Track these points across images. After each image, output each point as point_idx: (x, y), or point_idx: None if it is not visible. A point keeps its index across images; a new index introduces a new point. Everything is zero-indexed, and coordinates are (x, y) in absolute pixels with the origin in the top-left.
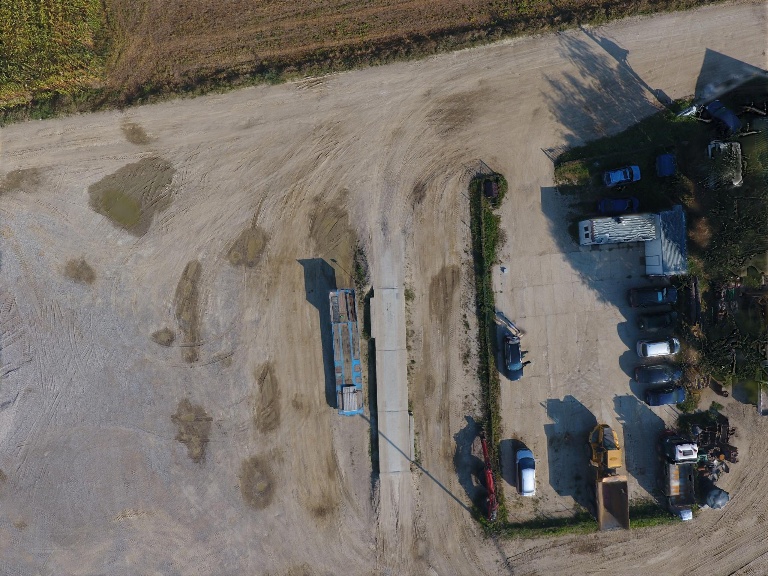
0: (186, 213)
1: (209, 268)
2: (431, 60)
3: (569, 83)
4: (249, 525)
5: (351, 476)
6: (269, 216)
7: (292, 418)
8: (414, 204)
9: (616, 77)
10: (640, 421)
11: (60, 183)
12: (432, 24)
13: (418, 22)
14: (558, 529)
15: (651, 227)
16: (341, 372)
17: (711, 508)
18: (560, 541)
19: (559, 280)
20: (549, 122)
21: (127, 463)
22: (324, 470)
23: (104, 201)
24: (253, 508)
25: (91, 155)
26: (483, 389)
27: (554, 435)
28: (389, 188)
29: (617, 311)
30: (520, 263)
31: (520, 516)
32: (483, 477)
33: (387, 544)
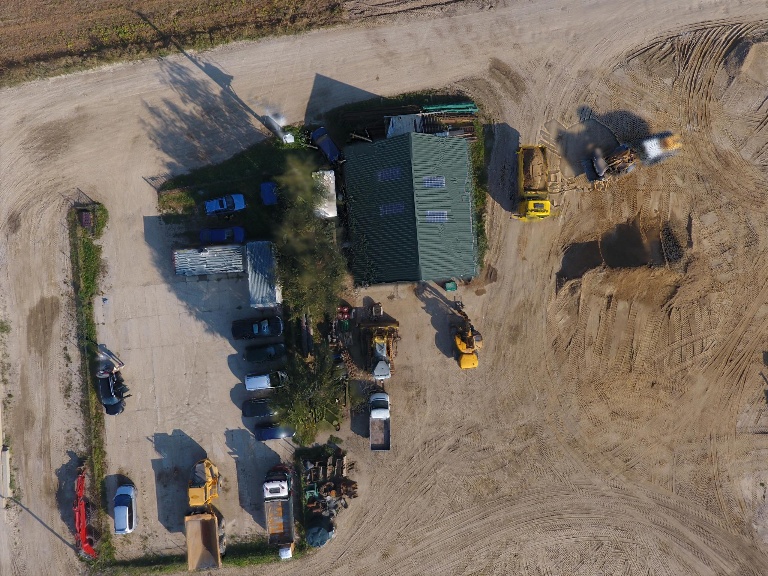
0: None
1: None
2: (24, 87)
3: (170, 110)
4: None
5: None
6: None
7: None
8: (8, 234)
9: (220, 103)
10: (254, 455)
11: None
12: (28, 50)
13: (13, 48)
14: (164, 567)
15: None
16: None
17: (331, 544)
18: None
19: (165, 311)
20: (150, 150)
21: None
22: None
23: None
24: None
25: None
26: (86, 423)
27: (162, 470)
28: None
29: (227, 343)
30: (123, 294)
31: (128, 553)
32: None
33: None
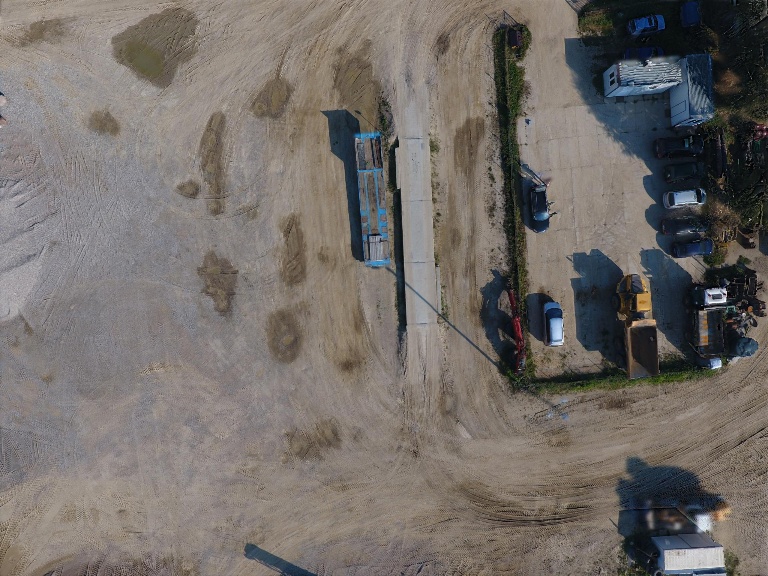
0: (210, 64)
1: (233, 119)
2: None
3: None
4: (276, 379)
5: (378, 330)
6: (293, 67)
7: (318, 271)
8: (438, 55)
9: None
10: (667, 275)
11: (83, 34)
12: None
13: None
14: (586, 383)
15: (677, 72)
16: (367, 222)
17: (739, 364)
18: (588, 396)
19: (584, 132)
20: None
21: (153, 316)
22: (351, 324)
23: (127, 52)
24: (280, 362)
25: (114, 6)
26: (509, 242)
27: (581, 289)
28: (413, 39)
29: (643, 164)
30: (545, 115)
31: (548, 371)
32: (511, 327)
33: (415, 399)
